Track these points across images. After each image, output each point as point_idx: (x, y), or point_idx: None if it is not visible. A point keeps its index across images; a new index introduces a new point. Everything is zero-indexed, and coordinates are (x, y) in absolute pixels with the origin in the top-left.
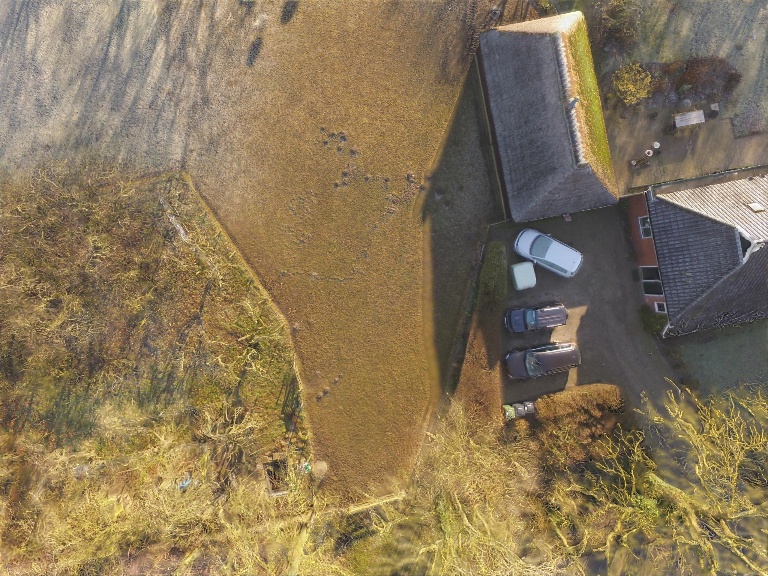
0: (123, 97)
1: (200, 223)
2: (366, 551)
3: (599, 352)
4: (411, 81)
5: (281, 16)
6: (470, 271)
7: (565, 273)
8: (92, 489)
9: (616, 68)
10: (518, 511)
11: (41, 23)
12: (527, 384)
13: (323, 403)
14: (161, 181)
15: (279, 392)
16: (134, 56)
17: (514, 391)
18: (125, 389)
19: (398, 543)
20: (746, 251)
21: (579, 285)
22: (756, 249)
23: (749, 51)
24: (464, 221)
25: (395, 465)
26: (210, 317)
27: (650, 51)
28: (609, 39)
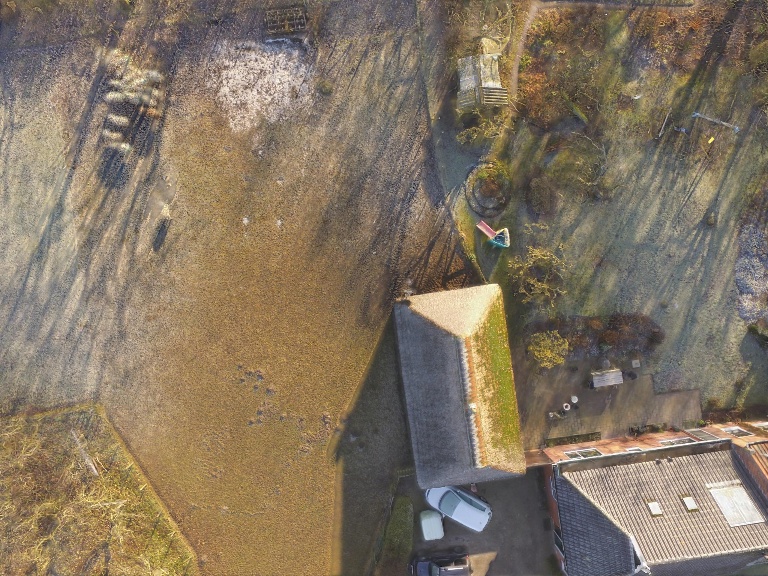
0: (40, 327)
1: (112, 455)
2: None
3: None
4: (332, 323)
5: (203, 253)
6: (381, 512)
7: None
8: None
9: (539, 319)
10: None
11: None
12: None
13: None
14: (75, 412)
15: None
16: (53, 288)
17: None
18: None
19: None
20: (637, 566)
21: (490, 531)
22: (645, 571)
23: (674, 309)
24: (378, 463)
25: None
26: None
27: (574, 304)
28: None
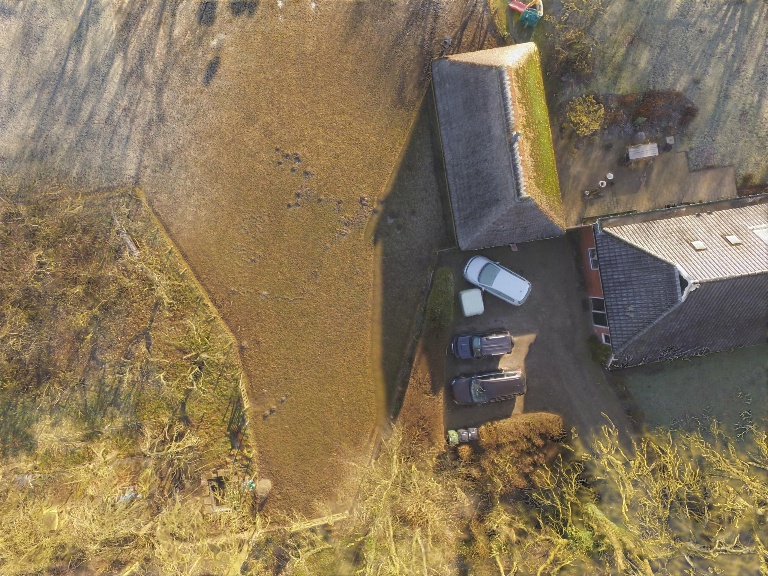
0: (79, 111)
1: (152, 239)
2: (308, 570)
3: (547, 380)
4: (367, 104)
5: (239, 36)
6: (420, 295)
7: (513, 301)
8: (27, 503)
9: (572, 98)
10: (461, 536)
11: (0, 36)
12: (473, 410)
13: (269, 422)
14: (114, 196)
15: (226, 409)
16: (91, 71)
17: (460, 416)
18: (72, 401)
19: (340, 564)
20: (684, 290)
21: (529, 313)
22: (692, 289)
23: (706, 85)
24: (415, 245)
25: (339, 486)
26: (159, 333)
27: (607, 82)
28: (566, 69)
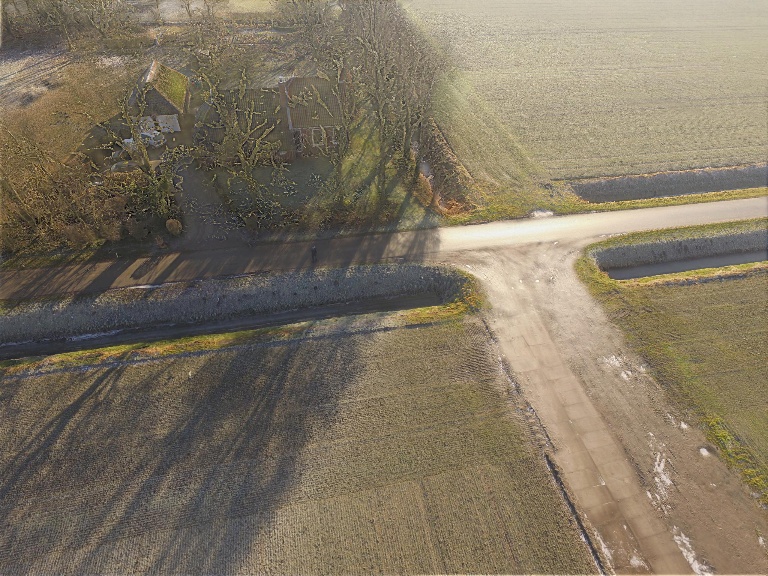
0: None
1: None
2: None
3: None
4: None
5: None
6: None
7: (151, 140)
8: None
9: None
10: None
11: None
12: None
13: None
14: None
15: None
16: None
17: None
18: None
19: None
20: None
21: None
22: None
23: None
24: None
25: (0, 217)
26: None
27: None
28: None
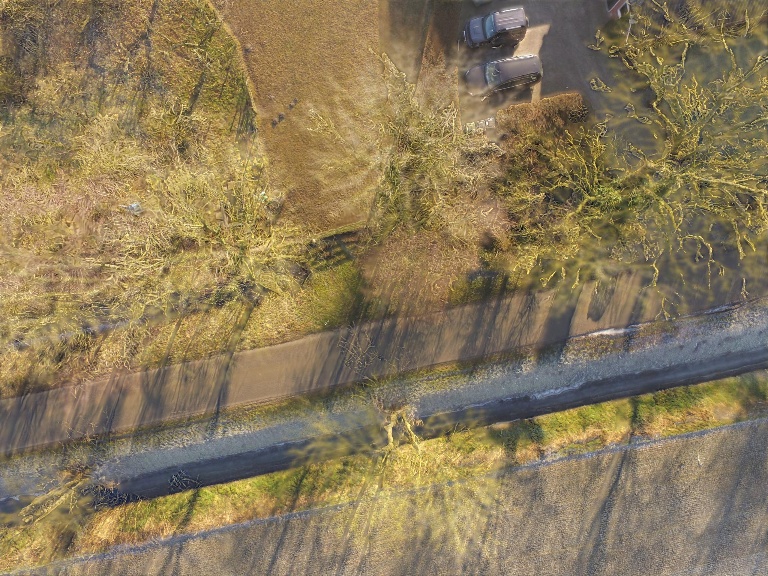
0: None
1: None
2: (327, 285)
3: (563, 74)
4: None
5: None
6: None
7: None
8: (30, 167)
9: None
10: (483, 243)
11: None
12: (489, 108)
13: (279, 130)
14: None
15: (233, 118)
16: None
17: (476, 116)
18: None
19: (360, 276)
20: None
21: (541, 3)
22: None
23: None
24: None
25: (355, 196)
26: None
27: None
28: None
